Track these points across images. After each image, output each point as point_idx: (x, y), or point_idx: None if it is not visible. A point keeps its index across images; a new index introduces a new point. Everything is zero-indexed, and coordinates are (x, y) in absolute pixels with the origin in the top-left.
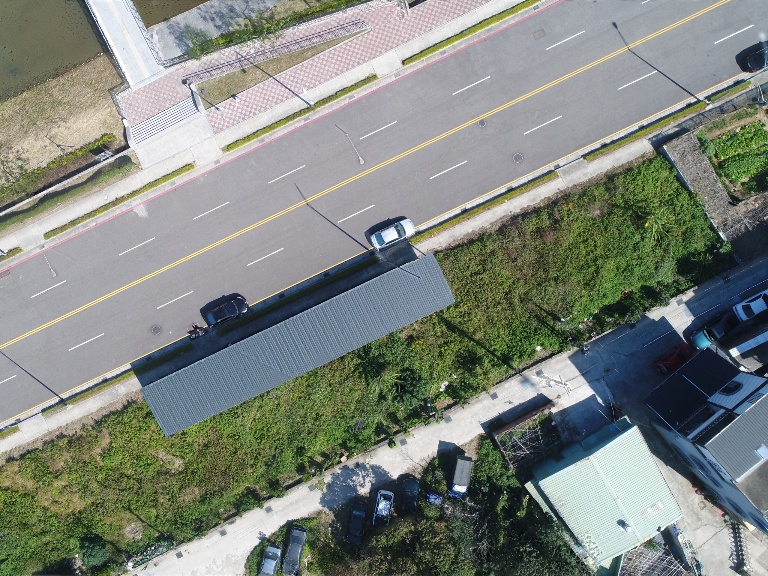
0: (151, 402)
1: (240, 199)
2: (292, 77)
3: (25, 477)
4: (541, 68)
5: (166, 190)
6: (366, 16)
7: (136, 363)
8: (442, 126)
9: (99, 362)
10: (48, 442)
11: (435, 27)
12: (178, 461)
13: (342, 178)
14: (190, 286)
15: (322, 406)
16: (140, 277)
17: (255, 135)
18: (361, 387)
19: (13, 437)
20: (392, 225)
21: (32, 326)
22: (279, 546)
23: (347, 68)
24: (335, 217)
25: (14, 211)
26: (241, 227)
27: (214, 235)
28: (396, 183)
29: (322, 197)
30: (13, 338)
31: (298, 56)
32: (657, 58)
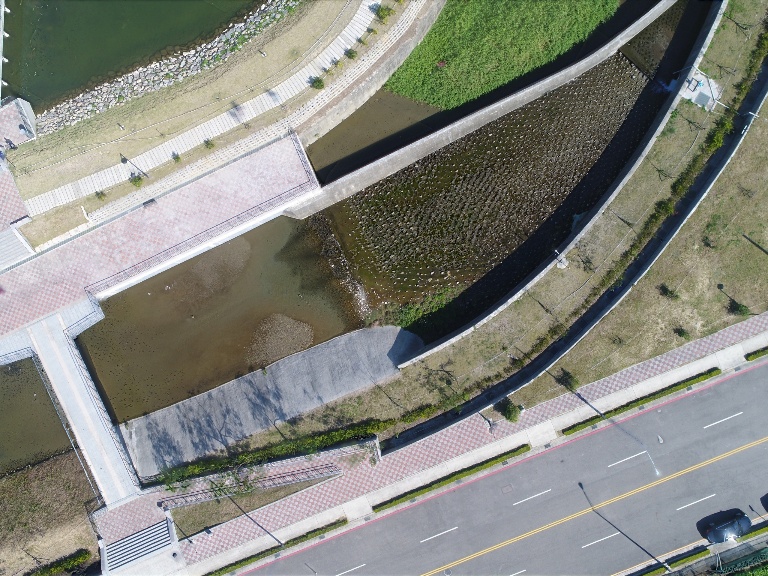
0: None
1: None
2: (264, 515)
3: None
4: (507, 523)
5: None
6: (339, 461)
7: None
8: (409, 572)
9: None
10: None
11: (406, 476)
12: None
13: None
14: None
15: None
16: None
17: (226, 571)
18: None
19: None
20: None
21: None
22: None
23: (318, 510)
24: None
25: None
26: None
27: None
28: None
29: None
30: None
31: (271, 494)
32: (620, 520)
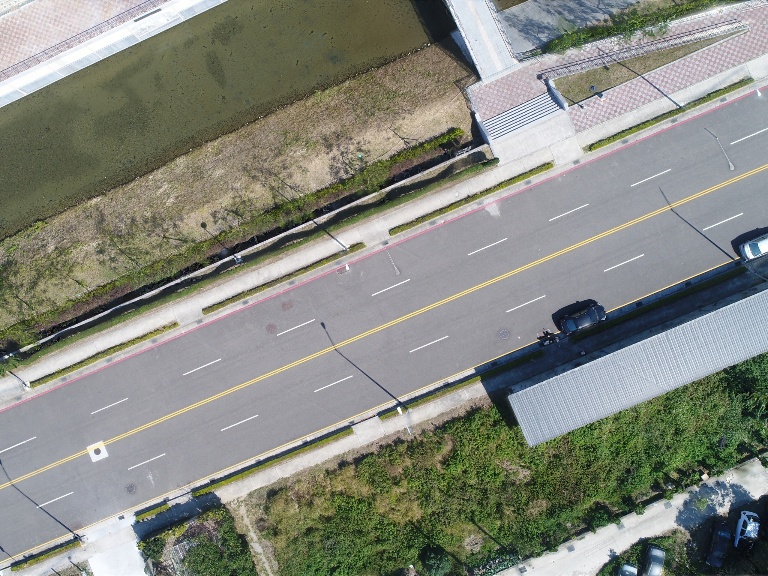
0: (518, 410)
1: (600, 201)
2: (662, 76)
3: (362, 482)
4: None
5: (521, 189)
6: (743, 16)
7: (481, 368)
8: None
9: (441, 365)
10: (385, 447)
11: None
12: (524, 472)
13: (710, 184)
14: (543, 290)
15: (685, 421)
16: (490, 279)
17: (621, 135)
18: (725, 403)
19: (347, 440)
20: (766, 235)
21: (372, 325)
22: (634, 565)
23: (721, 69)
24: (701, 224)
25: (359, 205)
26: (600, 231)
27: (571, 238)
28: (767, 191)
29: (688, 203)
30: (351, 337)
31: (668, 55)
32: None
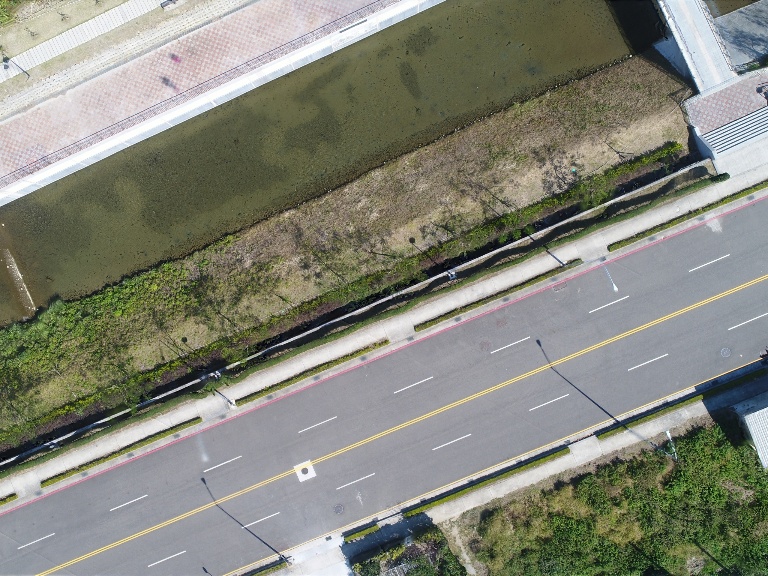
0: (754, 431)
1: None
2: None
3: (581, 503)
4: None
5: (744, 204)
6: None
7: (701, 386)
8: None
9: (661, 384)
10: (603, 467)
11: None
12: (747, 492)
13: None
14: (766, 307)
15: None
16: (711, 296)
17: None
18: None
19: (563, 460)
20: None
21: (589, 343)
22: None
23: None
24: None
25: (577, 220)
26: None
27: None
28: None
29: None
30: (568, 355)
31: None
32: None
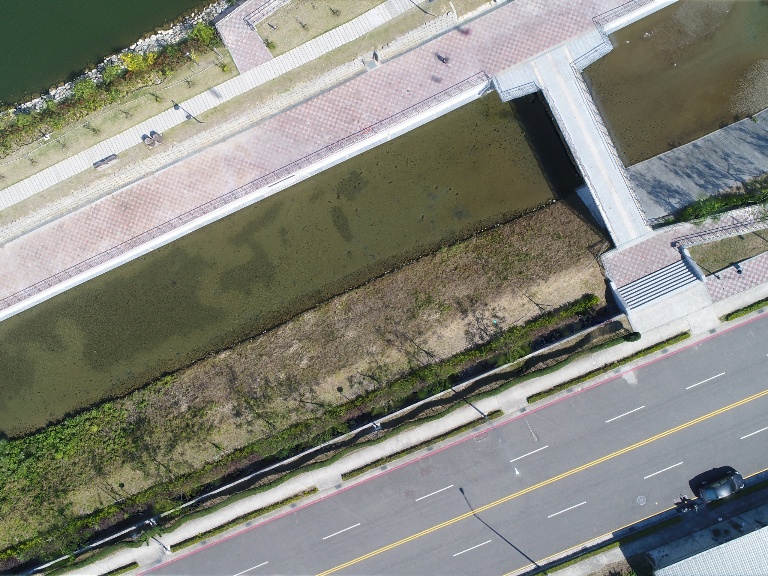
0: None
1: (737, 370)
2: None
3: None
4: None
5: (658, 358)
6: None
7: (618, 533)
8: None
9: (579, 530)
10: None
11: None
12: None
13: None
14: (680, 457)
15: None
16: (627, 446)
17: (758, 307)
18: None
19: None
20: None
21: (510, 491)
22: None
23: None
24: None
25: (497, 373)
26: (737, 399)
27: (708, 406)
28: None
29: None
30: (490, 502)
31: None
32: None
